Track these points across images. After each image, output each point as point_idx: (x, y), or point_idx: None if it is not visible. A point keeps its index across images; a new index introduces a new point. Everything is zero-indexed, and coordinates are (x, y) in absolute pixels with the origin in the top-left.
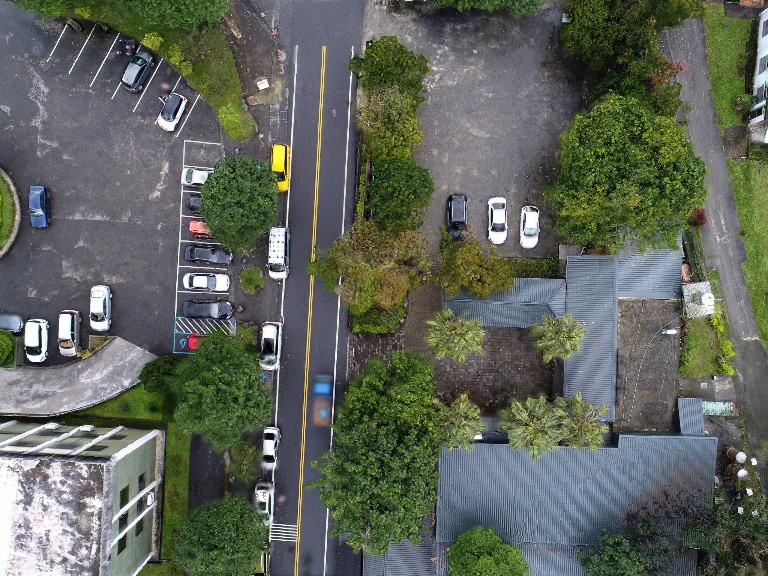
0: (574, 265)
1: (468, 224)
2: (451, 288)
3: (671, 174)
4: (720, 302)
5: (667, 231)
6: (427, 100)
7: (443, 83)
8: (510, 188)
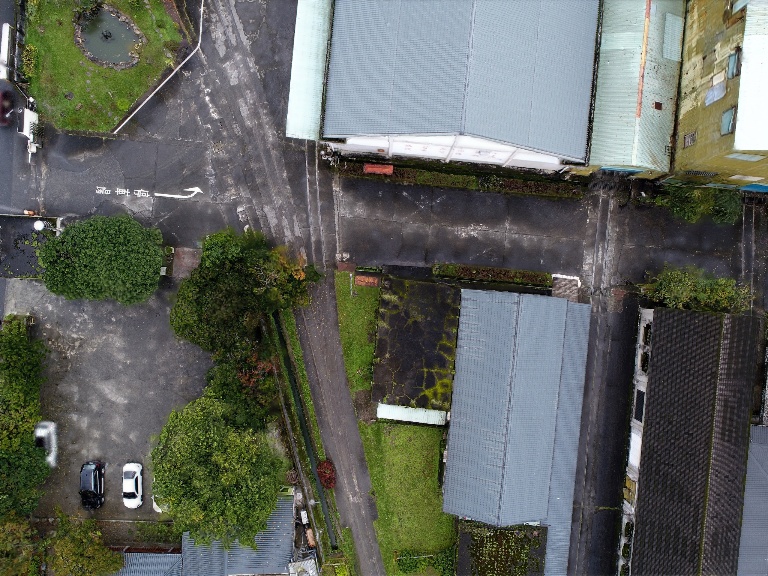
0: (188, 542)
1: (106, 487)
2: (58, 574)
3: (232, 489)
4: (353, 559)
5: (243, 534)
6: (67, 367)
7: (83, 350)
8: (147, 452)
